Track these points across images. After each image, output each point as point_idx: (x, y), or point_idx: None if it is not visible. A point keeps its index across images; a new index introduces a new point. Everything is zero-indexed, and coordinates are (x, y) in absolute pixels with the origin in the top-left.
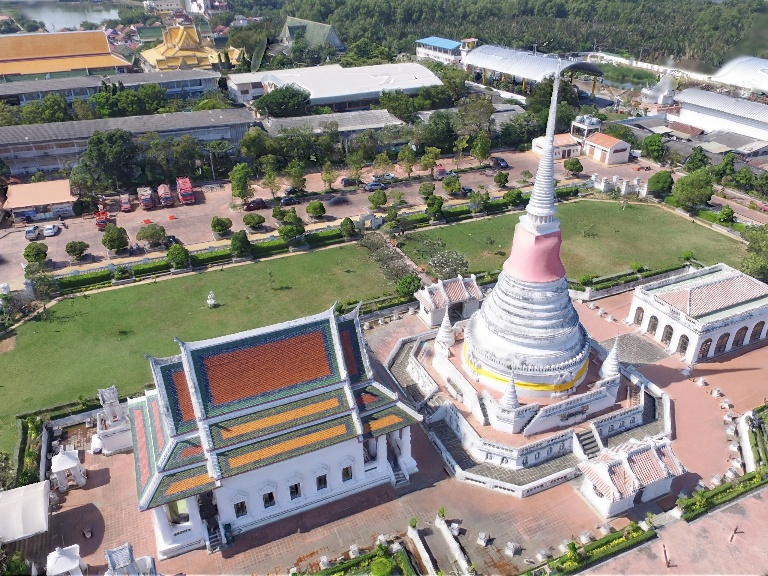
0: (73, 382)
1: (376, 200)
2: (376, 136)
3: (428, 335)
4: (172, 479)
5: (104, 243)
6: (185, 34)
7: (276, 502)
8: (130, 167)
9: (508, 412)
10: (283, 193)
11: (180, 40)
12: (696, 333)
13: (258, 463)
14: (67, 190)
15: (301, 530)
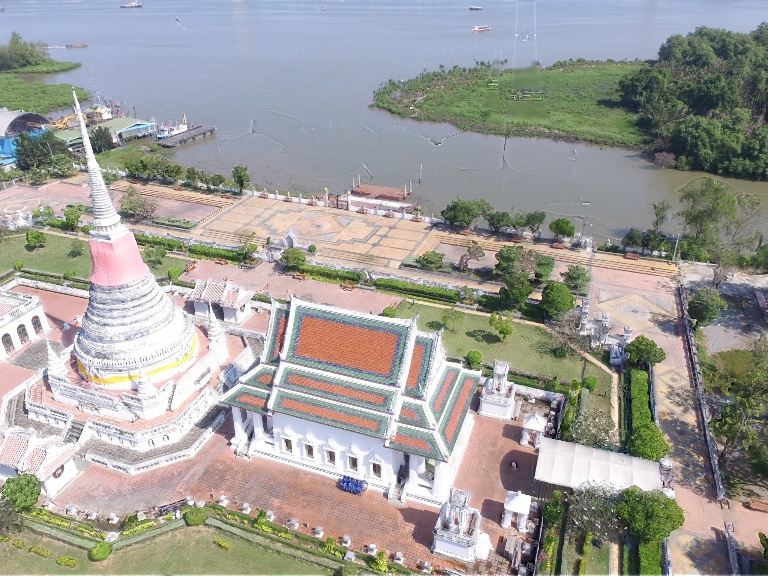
0: None
1: None
2: None
3: (129, 430)
4: None
5: None
6: None
7: None
8: None
9: None
10: None
11: None
12: None
13: None
14: None
15: None
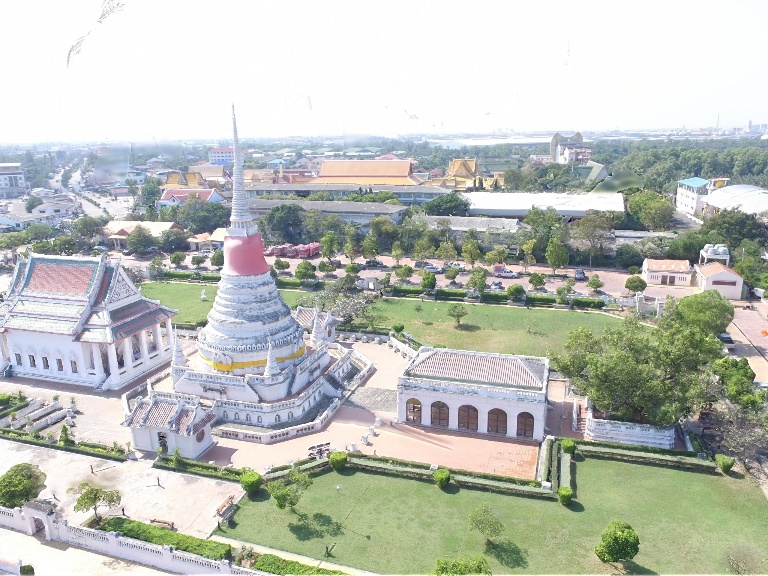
0: None
1: (399, 272)
2: (481, 236)
3: None
4: None
5: None
6: (460, 164)
7: (36, 365)
8: (298, 232)
9: None
10: (365, 262)
11: None
12: None
13: (20, 327)
14: None
15: (33, 385)
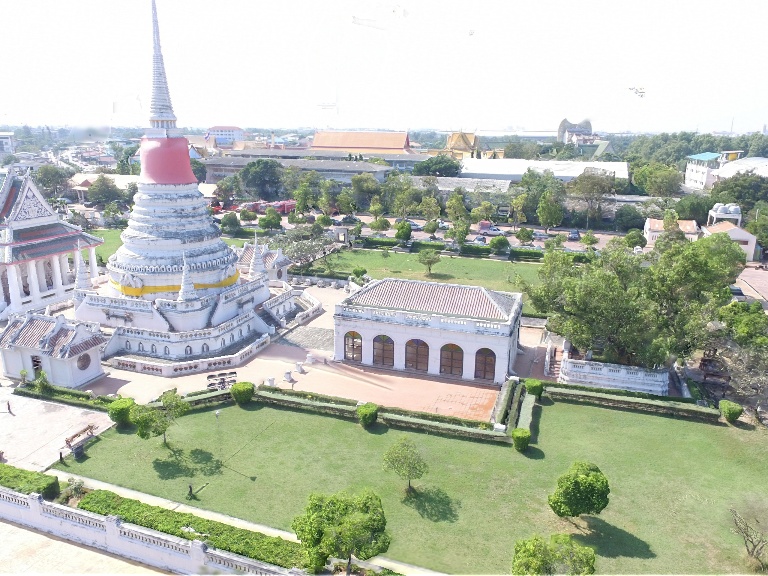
0: None
1: (373, 224)
2: (469, 196)
3: None
4: None
5: None
6: (458, 137)
7: None
8: None
9: None
10: None
11: None
12: None
13: None
14: (213, 190)
15: None
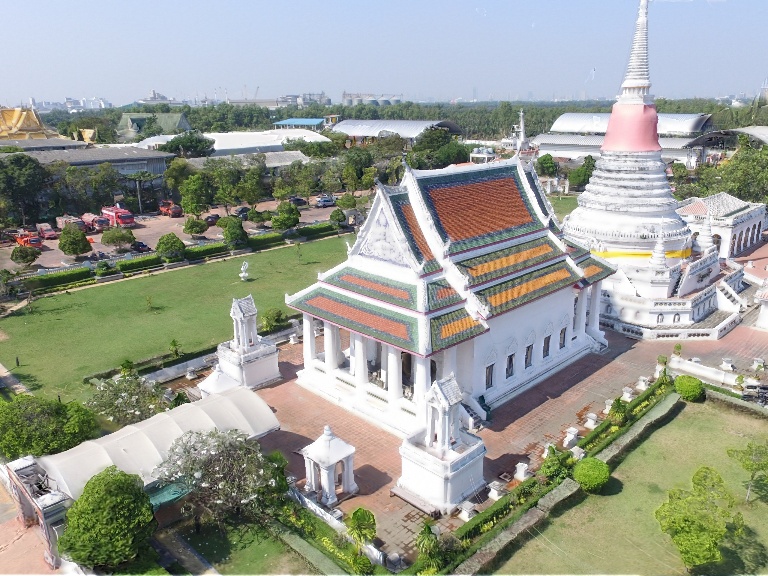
0: (132, 347)
1: (347, 203)
2: None
3: None
4: (440, 322)
5: (62, 247)
6: (25, 114)
7: (515, 370)
8: (35, 201)
9: (662, 273)
10: (233, 213)
11: (18, 121)
12: (728, 227)
13: (515, 302)
14: None
15: (551, 397)
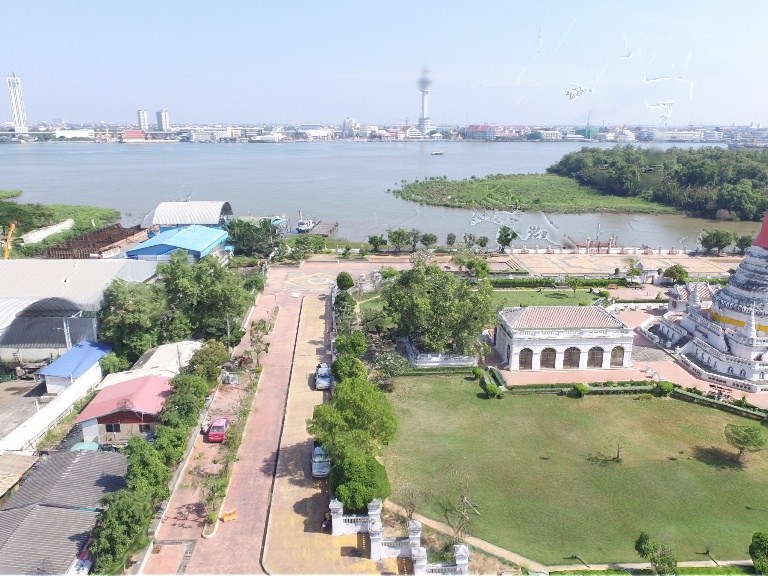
0: None
1: None
2: None
3: None
4: None
5: None
6: None
7: None
8: None
9: None
10: None
11: None
12: None
13: None
14: None
15: None
